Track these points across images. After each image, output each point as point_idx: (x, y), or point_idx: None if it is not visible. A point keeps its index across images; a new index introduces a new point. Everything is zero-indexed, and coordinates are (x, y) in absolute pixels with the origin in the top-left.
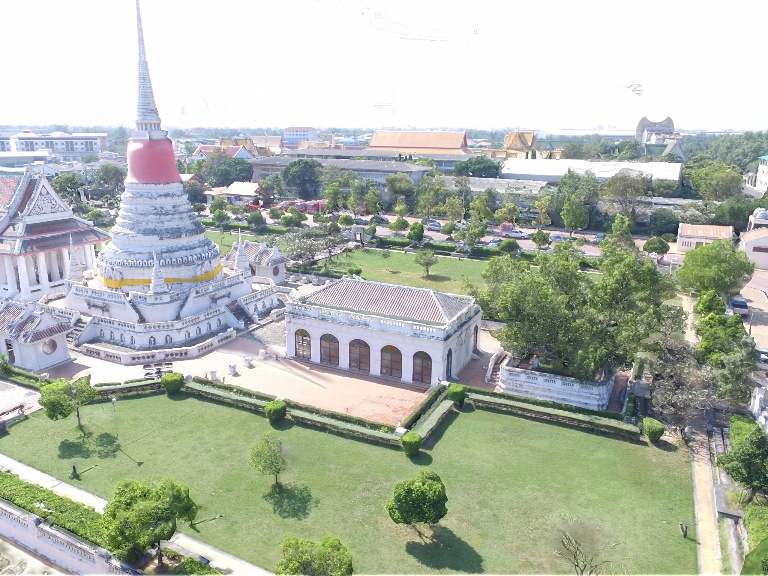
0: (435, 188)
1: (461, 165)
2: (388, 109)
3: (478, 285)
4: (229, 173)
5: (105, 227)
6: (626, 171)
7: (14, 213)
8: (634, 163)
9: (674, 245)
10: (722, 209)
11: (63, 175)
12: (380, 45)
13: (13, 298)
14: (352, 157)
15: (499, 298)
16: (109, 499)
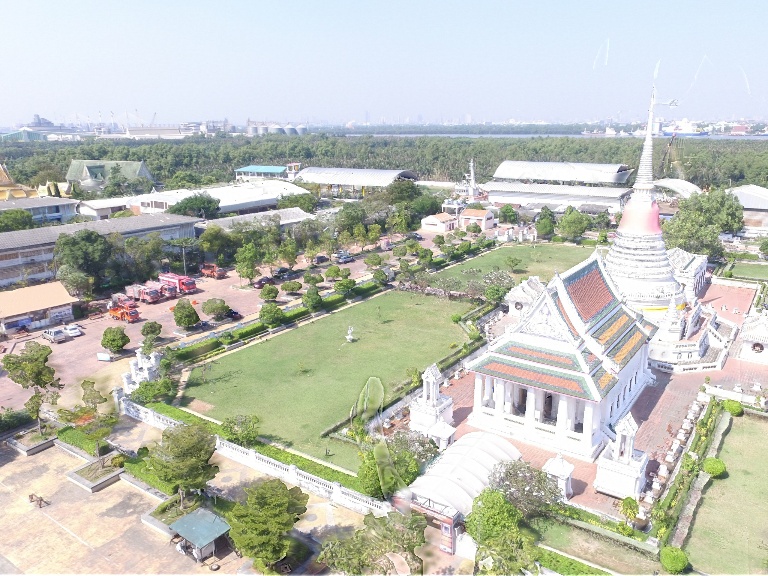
0: (265, 230)
1: (199, 206)
2: None
3: None
4: None
5: (192, 398)
6: None
7: None
8: (264, 184)
9: (427, 230)
10: (424, 204)
11: (11, 357)
12: None
13: None
14: None
15: (704, 238)
16: None
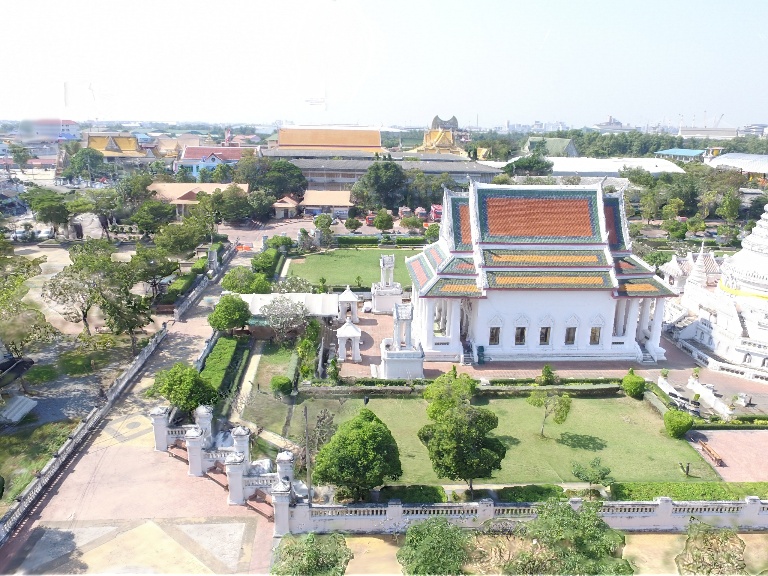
0: None
1: (523, 164)
2: (320, 105)
3: None
4: (284, 180)
5: (304, 257)
6: (724, 167)
7: (609, 244)
8: (635, 159)
9: None
10: None
11: (202, 192)
12: (309, 35)
13: (653, 351)
14: (317, 158)
15: None
16: None
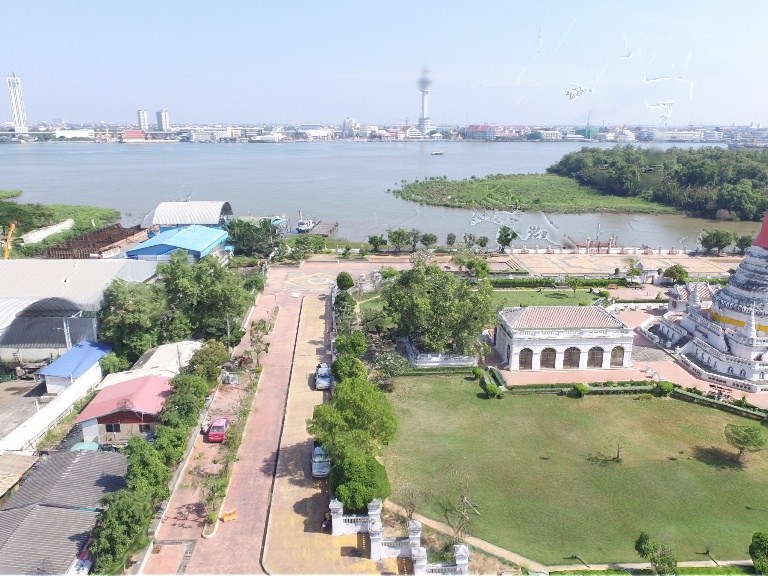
0: None
1: None
2: None
3: (646, 453)
4: None
5: None
6: None
7: None
8: None
9: None
10: None
11: None
12: None
13: None
14: None
15: None
16: None
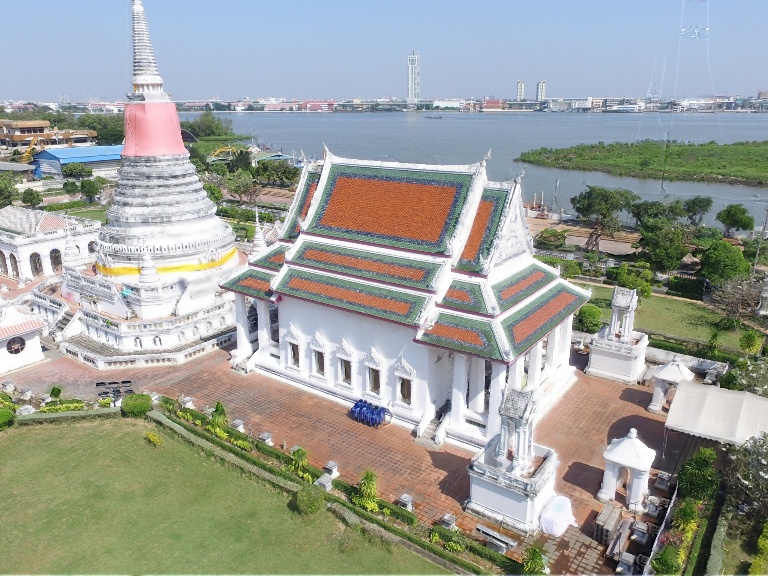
0: None
1: None
2: None
3: None
4: None
5: None
6: None
7: None
8: None
9: None
10: None
11: None
12: None
13: None
14: None
15: None
16: (226, 221)
